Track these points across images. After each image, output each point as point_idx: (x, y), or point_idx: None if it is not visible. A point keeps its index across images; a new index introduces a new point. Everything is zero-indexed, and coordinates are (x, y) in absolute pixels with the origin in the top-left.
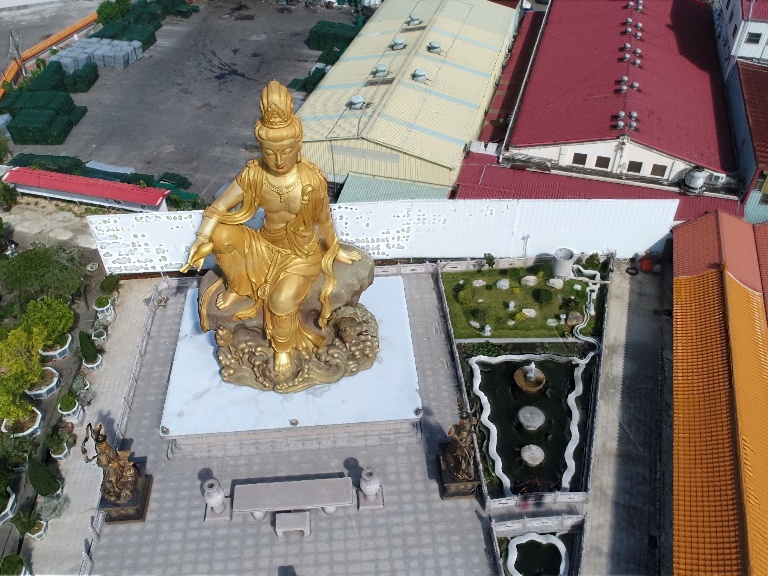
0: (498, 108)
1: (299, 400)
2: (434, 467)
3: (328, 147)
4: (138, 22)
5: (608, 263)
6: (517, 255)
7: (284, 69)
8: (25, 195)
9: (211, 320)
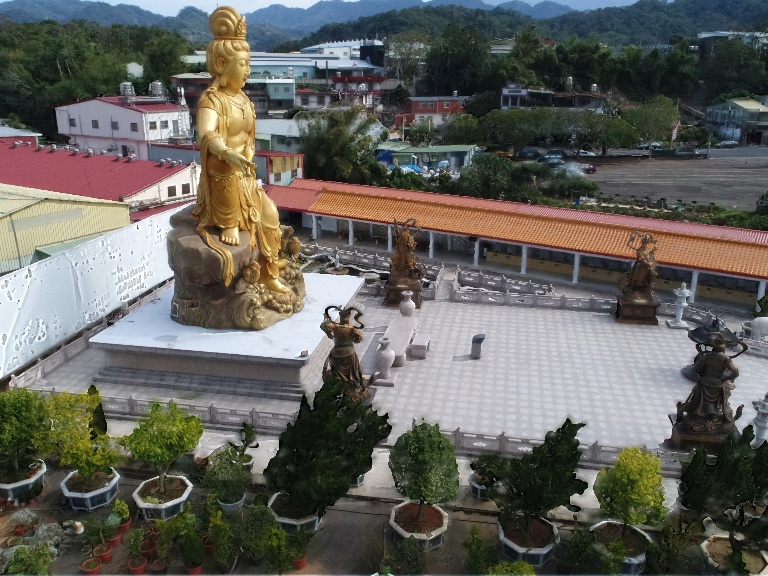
0: None
1: (314, 307)
2: (391, 307)
3: (8, 225)
4: None
5: None
6: None
7: None
8: None
9: (235, 261)
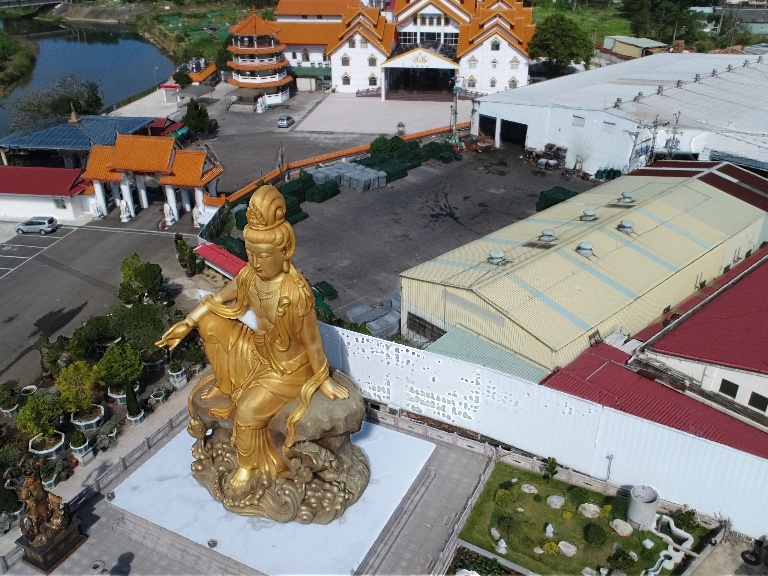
0: (685, 309)
1: (236, 524)
2: None
3: (442, 292)
4: (401, 158)
5: (719, 532)
6: (600, 476)
7: (498, 222)
8: (211, 268)
9: (194, 407)
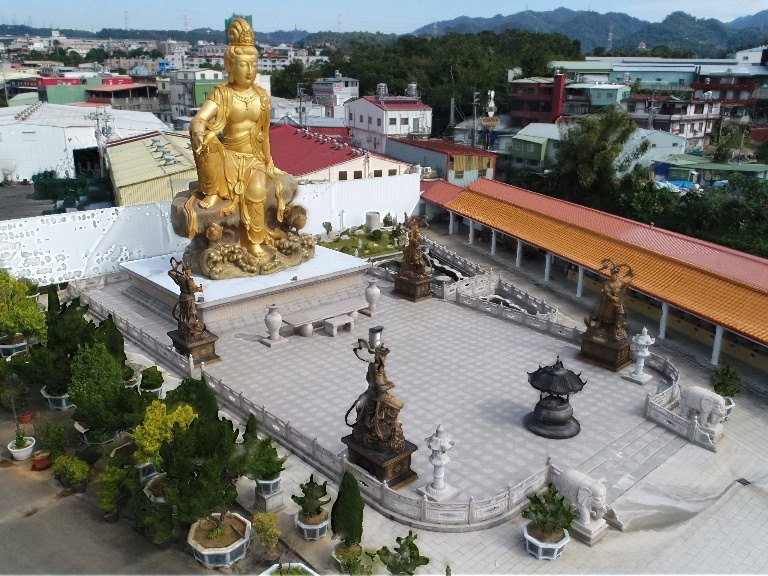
0: None
1: (284, 274)
2: (394, 296)
3: (168, 182)
4: None
5: None
6: None
7: (25, 209)
8: None
9: (200, 221)
